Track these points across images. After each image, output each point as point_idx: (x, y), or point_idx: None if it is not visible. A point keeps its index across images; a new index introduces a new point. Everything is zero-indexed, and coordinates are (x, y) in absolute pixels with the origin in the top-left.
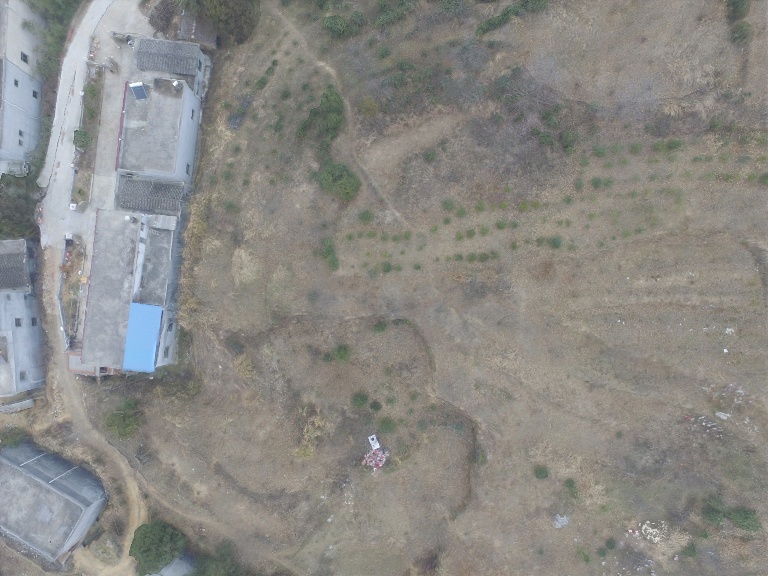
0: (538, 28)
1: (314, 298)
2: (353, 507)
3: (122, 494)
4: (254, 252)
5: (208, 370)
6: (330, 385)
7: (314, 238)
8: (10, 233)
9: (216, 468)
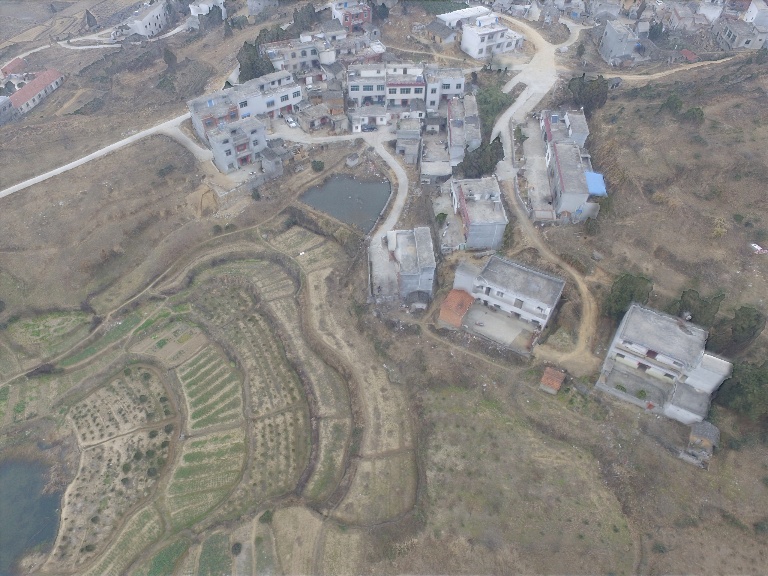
0: (757, 84)
1: (699, 158)
2: (764, 278)
3: (578, 290)
4: (652, 149)
5: (630, 212)
6: (717, 209)
7: (687, 138)
8: (492, 165)
9: (656, 254)
